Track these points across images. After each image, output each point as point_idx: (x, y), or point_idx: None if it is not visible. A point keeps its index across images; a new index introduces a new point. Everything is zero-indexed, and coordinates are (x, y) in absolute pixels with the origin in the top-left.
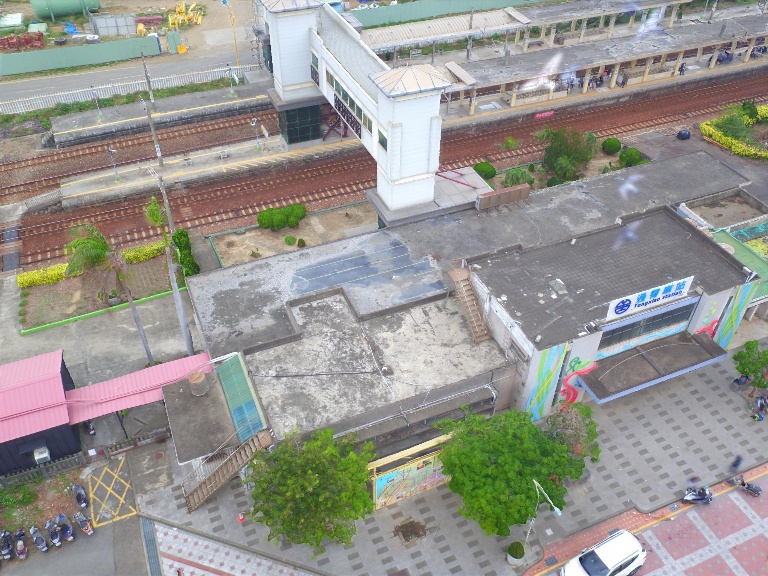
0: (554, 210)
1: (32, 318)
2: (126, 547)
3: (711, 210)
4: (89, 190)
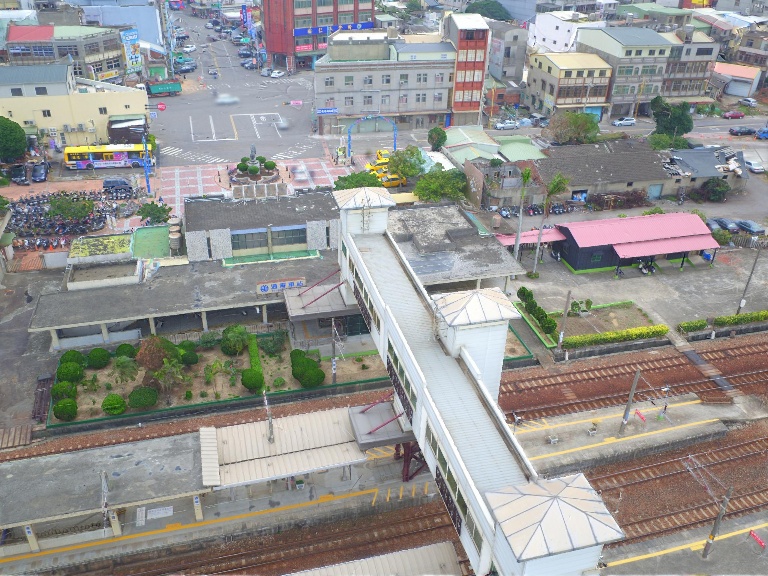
0: (240, 289)
1: (635, 312)
2: (516, 227)
3: None
4: (681, 407)
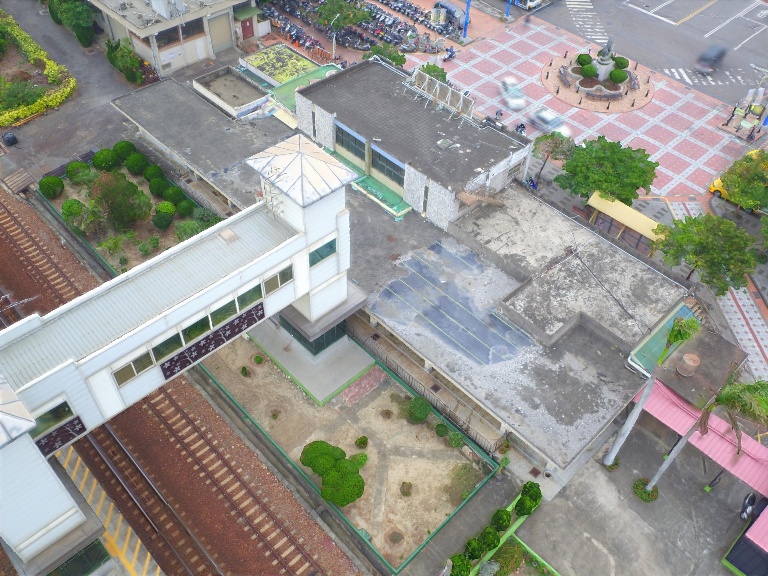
0: None
1: None
2: None
3: (228, 100)
4: None
